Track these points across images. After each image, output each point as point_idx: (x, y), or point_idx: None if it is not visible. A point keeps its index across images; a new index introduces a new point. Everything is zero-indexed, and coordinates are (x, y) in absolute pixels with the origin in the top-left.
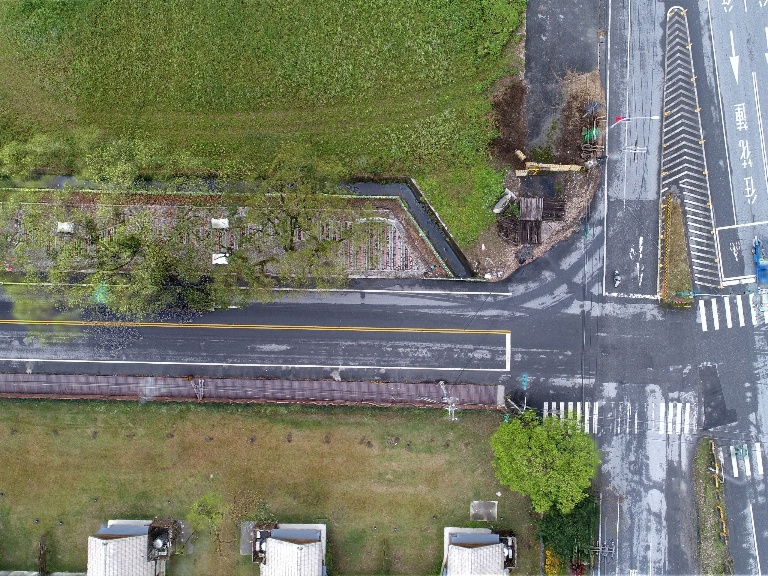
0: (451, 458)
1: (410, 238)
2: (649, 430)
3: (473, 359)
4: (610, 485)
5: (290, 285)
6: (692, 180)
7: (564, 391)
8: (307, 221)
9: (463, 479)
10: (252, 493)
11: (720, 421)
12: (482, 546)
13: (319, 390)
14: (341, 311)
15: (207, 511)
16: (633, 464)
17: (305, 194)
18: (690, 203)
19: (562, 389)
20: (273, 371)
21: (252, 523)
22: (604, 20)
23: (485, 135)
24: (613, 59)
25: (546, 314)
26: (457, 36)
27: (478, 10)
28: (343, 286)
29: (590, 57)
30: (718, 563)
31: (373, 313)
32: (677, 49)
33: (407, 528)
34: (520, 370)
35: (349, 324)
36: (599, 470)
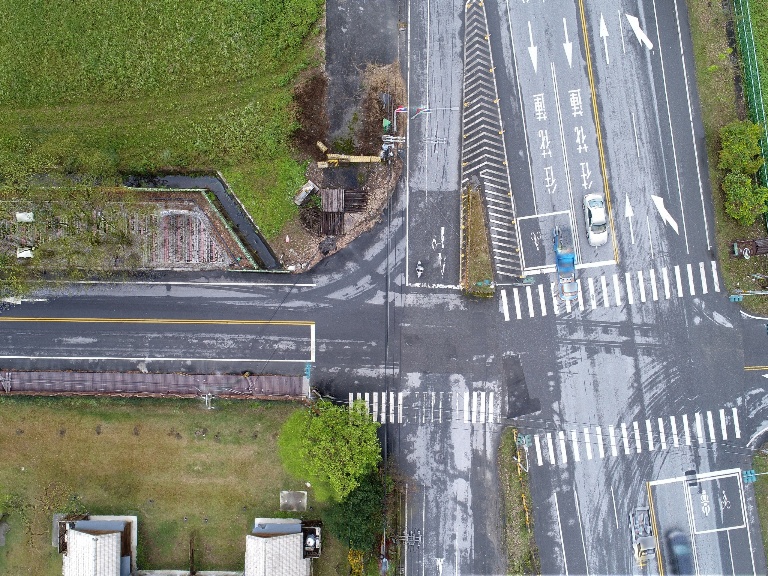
0: (259, 449)
1: (216, 230)
2: (453, 419)
3: (278, 350)
4: (416, 475)
5: (97, 278)
6: (492, 170)
7: (369, 381)
8: (112, 214)
9: (272, 470)
10: (63, 485)
11: (524, 410)
12: (278, 536)
13: (125, 382)
14: (147, 303)
15: (18, 503)
16: (438, 453)
17: (109, 187)
18: (491, 193)
19: (367, 379)
20: (80, 364)
21: (63, 515)
22: (404, 12)
23: (287, 127)
24: (413, 50)
25: (350, 305)
26: (258, 29)
27: (279, 3)
28: (149, 279)
29: (390, 49)
30: (524, 551)
31: (178, 305)
32: (476, 40)
33: (218, 519)
34: (325, 361)
35: (155, 316)
36: (405, 460)
